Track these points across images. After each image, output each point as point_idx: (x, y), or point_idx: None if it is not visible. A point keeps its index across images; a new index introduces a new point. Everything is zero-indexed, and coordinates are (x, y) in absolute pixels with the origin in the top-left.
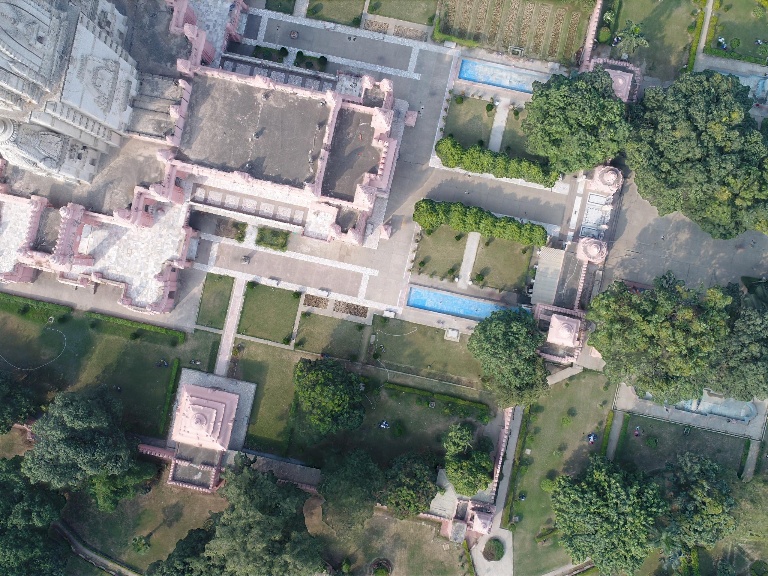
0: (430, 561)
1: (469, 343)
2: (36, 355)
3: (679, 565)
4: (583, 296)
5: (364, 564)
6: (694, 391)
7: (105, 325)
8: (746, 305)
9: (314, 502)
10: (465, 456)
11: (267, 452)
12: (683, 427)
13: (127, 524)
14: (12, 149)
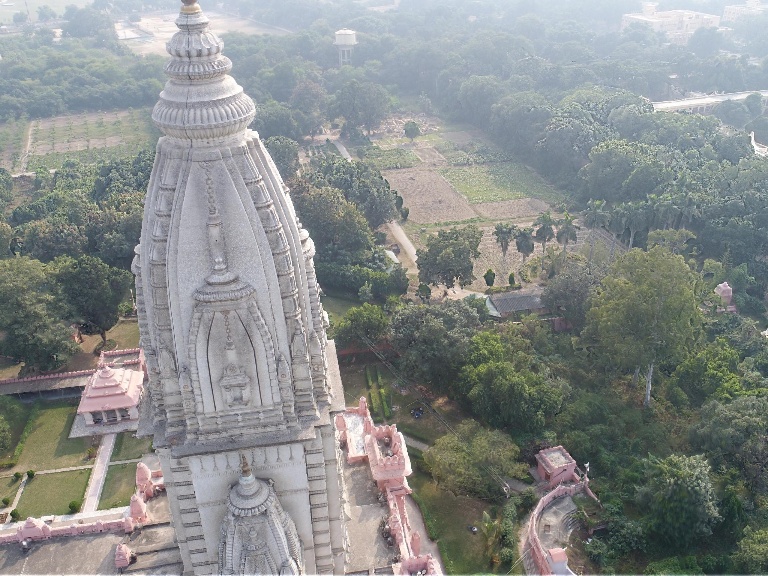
0: None
1: None
2: None
3: None
4: None
5: None
6: None
7: None
8: None
9: None
10: None
11: (58, 400)
12: None
13: None
14: None
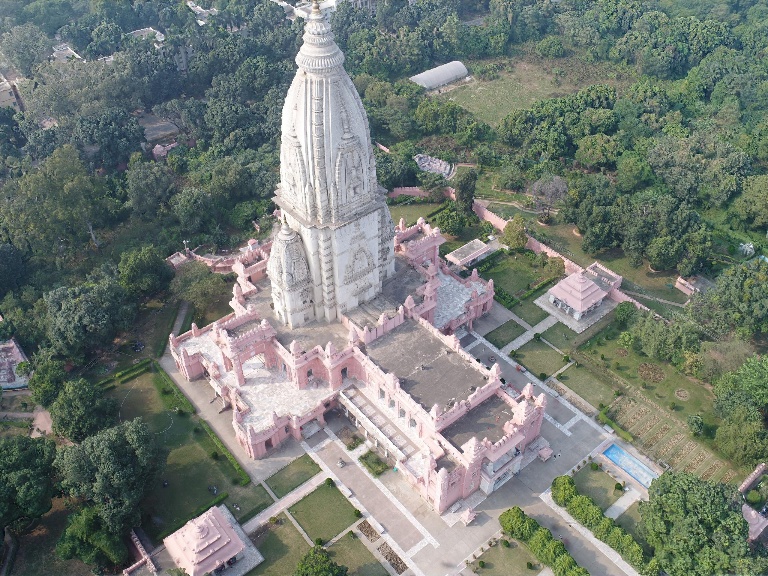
0: None
1: None
2: None
3: None
4: None
5: None
6: None
7: (204, 436)
8: None
9: None
10: None
11: None
12: None
13: None
14: (281, 250)
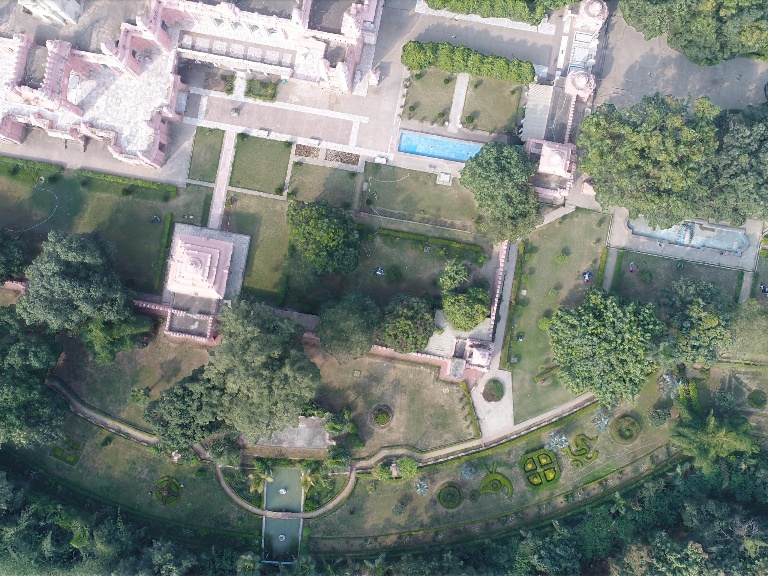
0: (430, 405)
1: (461, 174)
2: (27, 216)
3: (678, 398)
4: (573, 135)
5: (364, 411)
6: (686, 209)
7: (96, 183)
8: (734, 123)
9: (312, 351)
10: (461, 293)
11: None
12: (677, 261)
13: (125, 381)
14: None
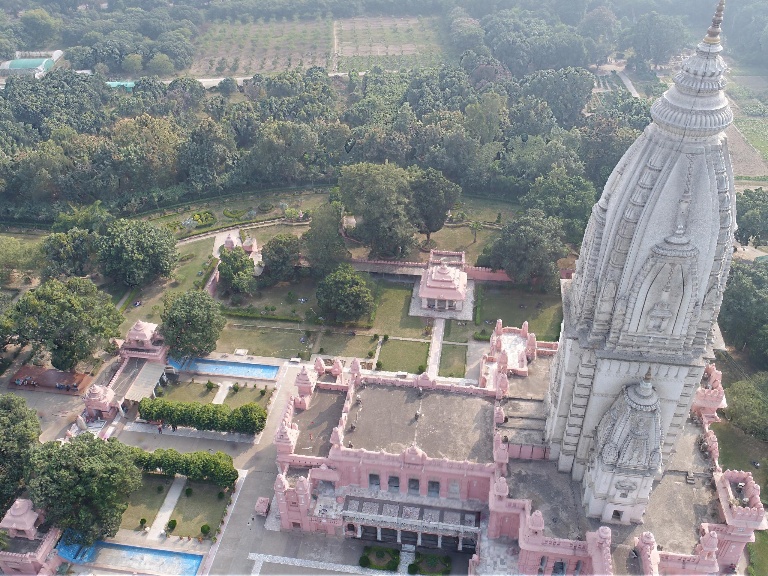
0: None
1: None
2: None
3: None
4: None
5: None
6: None
7: None
8: None
9: None
10: None
11: (396, 282)
12: None
13: None
14: None
